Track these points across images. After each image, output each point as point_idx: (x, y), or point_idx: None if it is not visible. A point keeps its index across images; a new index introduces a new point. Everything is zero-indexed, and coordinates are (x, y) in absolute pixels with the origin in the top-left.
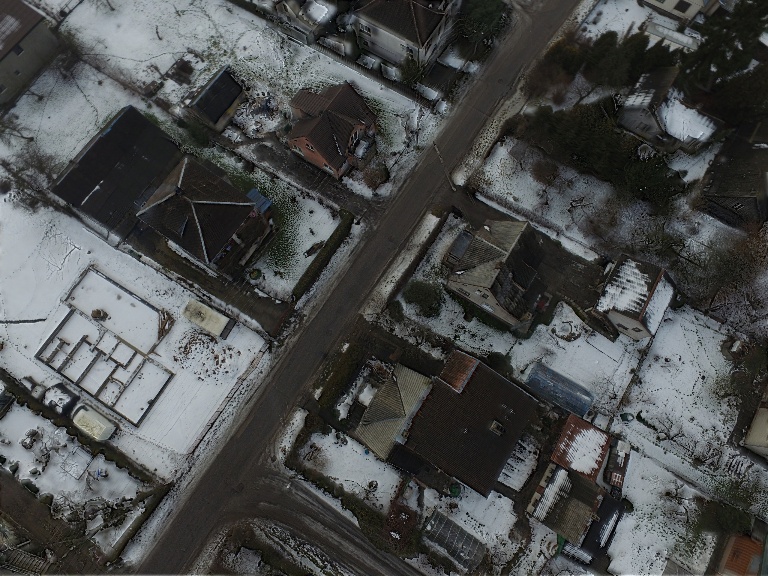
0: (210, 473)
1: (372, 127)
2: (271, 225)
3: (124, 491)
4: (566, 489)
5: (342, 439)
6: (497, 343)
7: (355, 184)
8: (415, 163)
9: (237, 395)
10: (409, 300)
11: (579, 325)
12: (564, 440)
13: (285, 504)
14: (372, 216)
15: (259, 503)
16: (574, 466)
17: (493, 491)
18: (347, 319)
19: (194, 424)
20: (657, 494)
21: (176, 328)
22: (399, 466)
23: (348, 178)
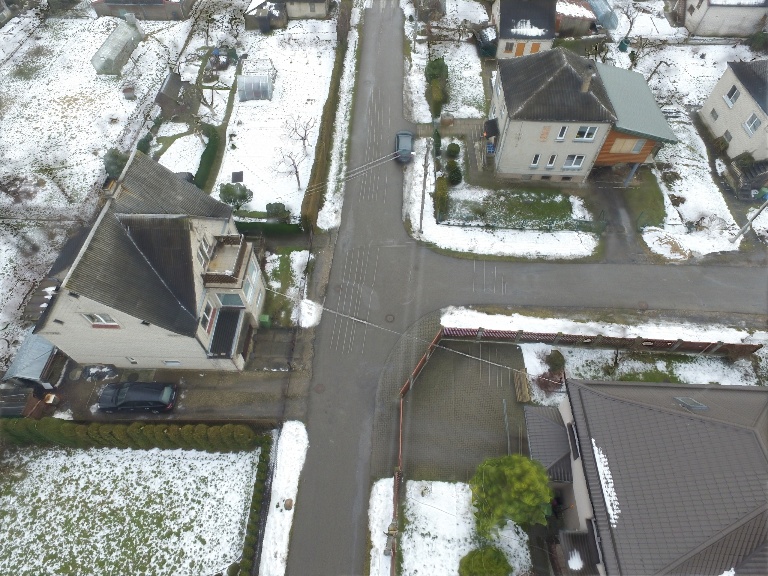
0: None
1: None
2: None
3: None
4: None
5: None
6: None
7: None
8: None
9: None
10: None
11: (658, 11)
12: None
13: None
14: None
15: None
16: None
17: (485, 10)
18: None
19: None
20: None
21: None
22: None
23: None
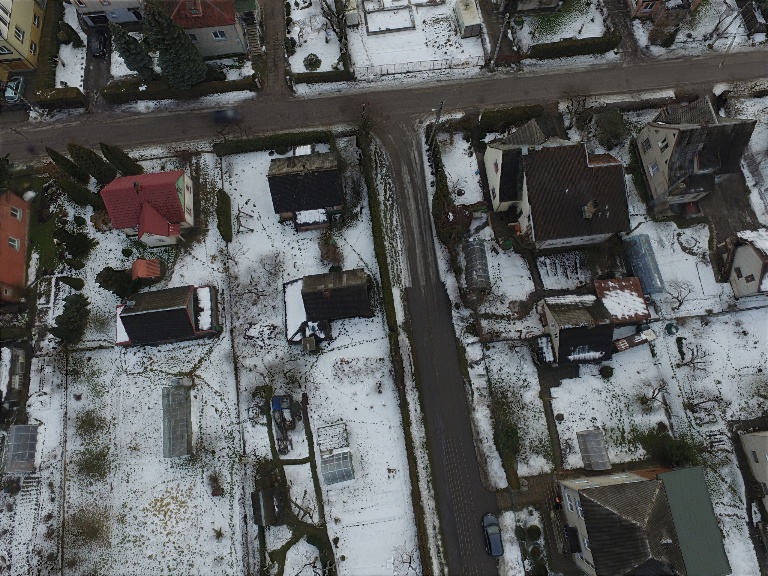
0: (379, 94)
1: (695, 3)
2: (559, 4)
3: (328, 58)
4: (585, 304)
5: (470, 151)
6: (630, 202)
7: (641, 30)
8: (698, 54)
9: (437, 72)
10: (601, 119)
11: (703, 249)
12: (615, 282)
13: (402, 149)
14: (630, 57)
15: (389, 134)
16: (605, 300)
17: (529, 271)
18: (547, 96)
19: (398, 62)
20: (637, 390)
21: (441, 7)
22: (502, 171)
23: (640, 22)
